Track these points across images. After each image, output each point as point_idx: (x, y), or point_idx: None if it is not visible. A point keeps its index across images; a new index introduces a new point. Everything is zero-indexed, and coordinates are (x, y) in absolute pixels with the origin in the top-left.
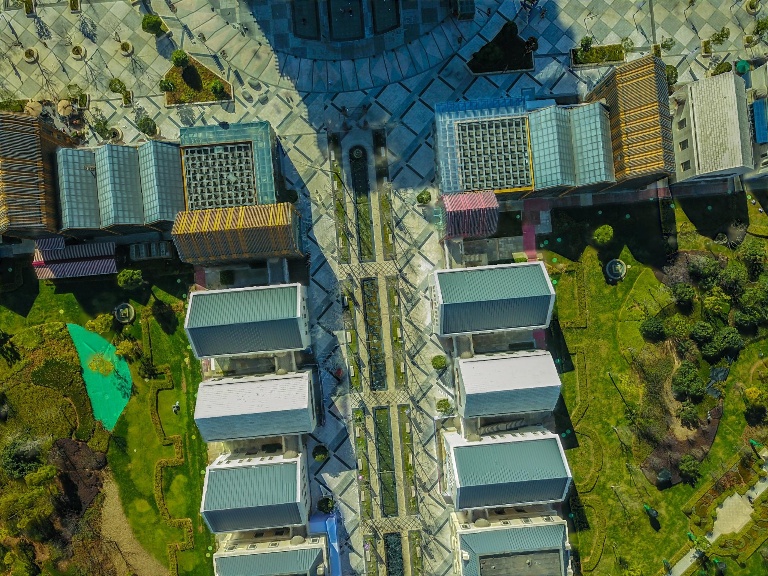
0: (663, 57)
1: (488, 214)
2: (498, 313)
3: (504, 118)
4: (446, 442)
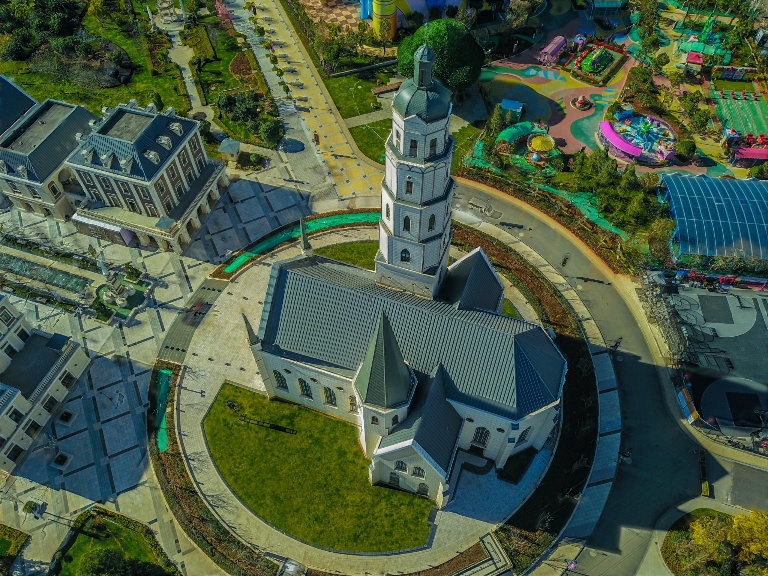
0: None
1: None
2: None
3: None
4: None
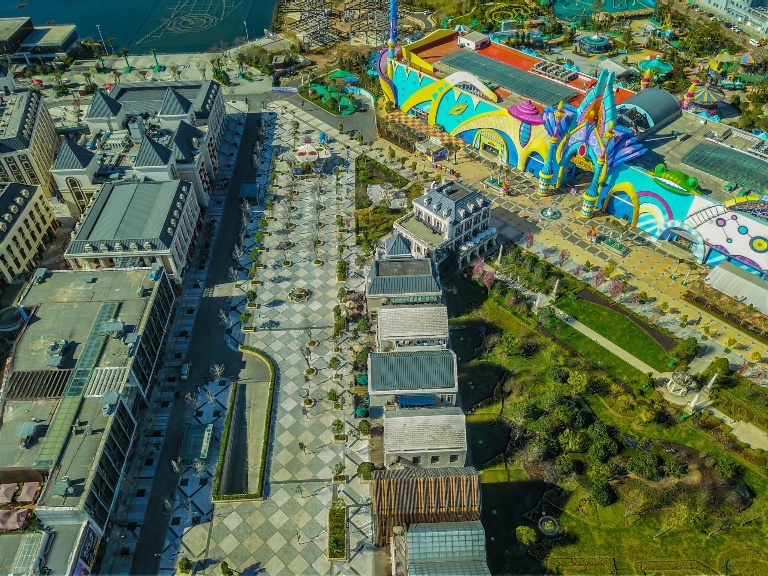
0: (344, 474)
1: None
2: None
3: None
4: None
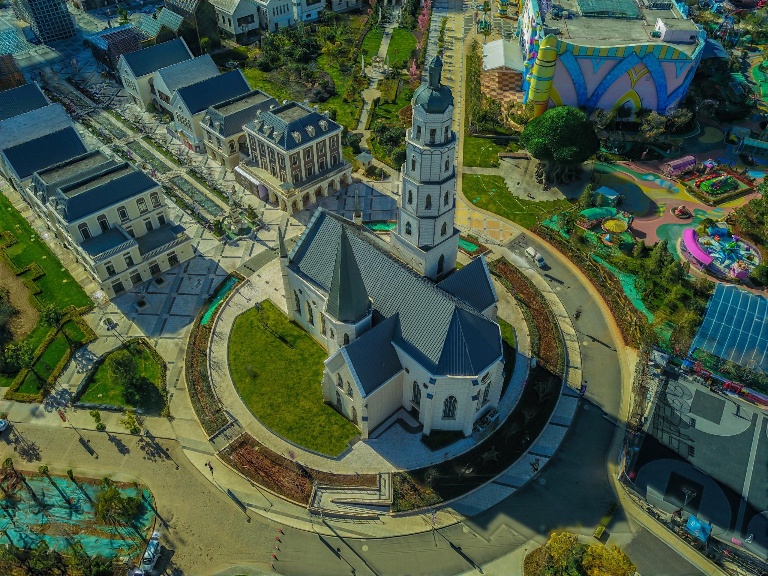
0: None
1: (131, 40)
2: (159, 56)
3: (124, 29)
4: (175, 121)
